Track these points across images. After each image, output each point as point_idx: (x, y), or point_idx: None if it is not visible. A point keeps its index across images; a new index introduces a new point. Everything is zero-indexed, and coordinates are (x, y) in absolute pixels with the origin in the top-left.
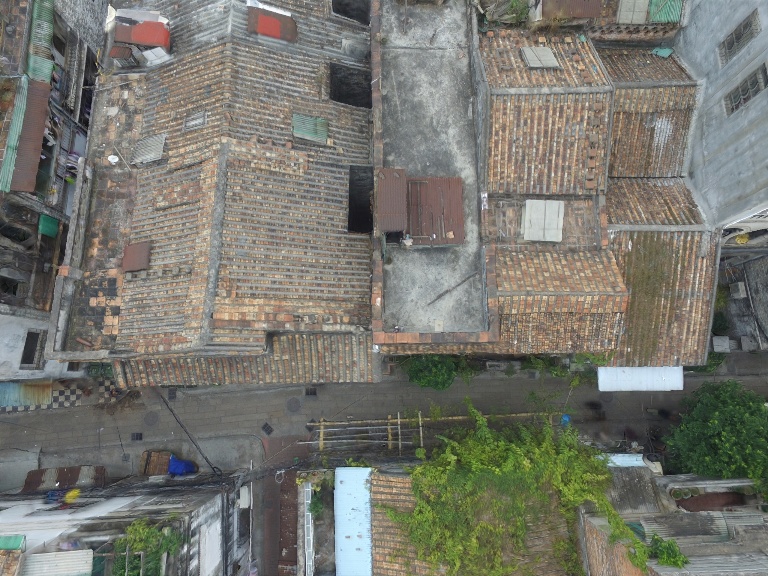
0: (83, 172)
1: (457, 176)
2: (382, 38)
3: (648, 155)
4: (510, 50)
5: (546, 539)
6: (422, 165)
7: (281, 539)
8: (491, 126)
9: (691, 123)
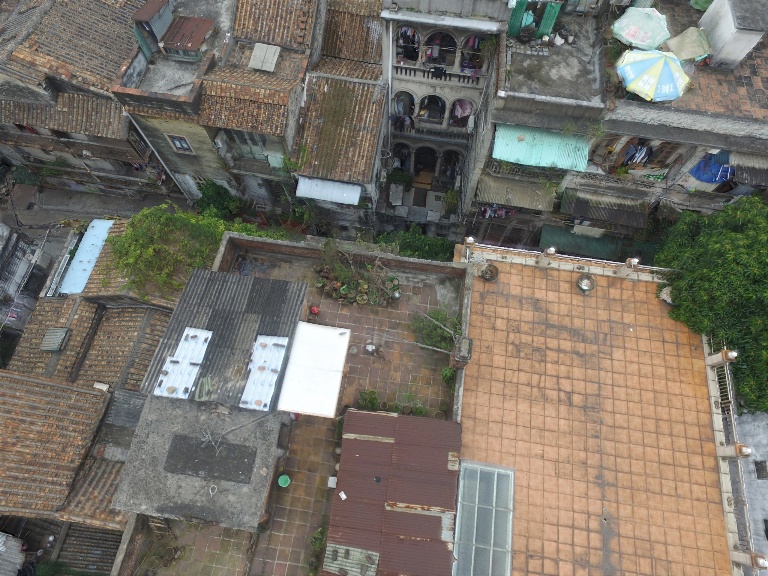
0: None
1: (218, 25)
2: None
3: (365, 46)
4: None
5: None
6: (198, 16)
7: None
8: None
9: None
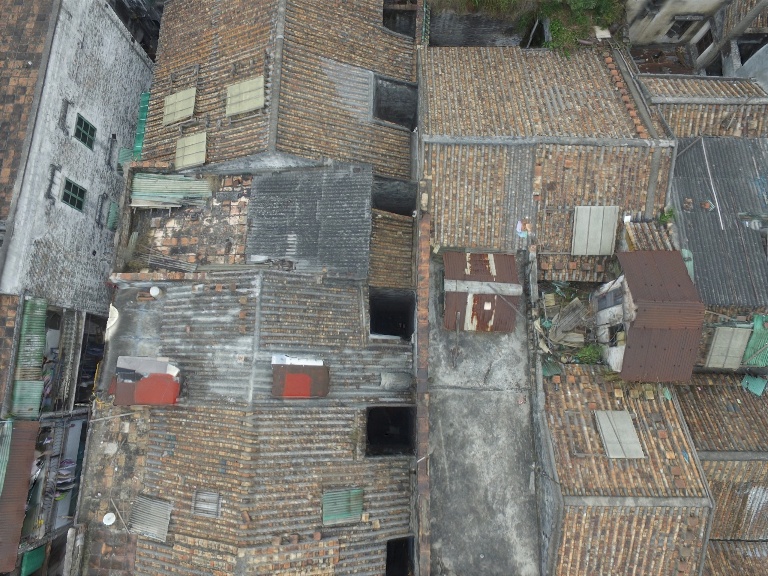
0: (73, 549)
1: (516, 573)
2: (428, 377)
3: (738, 520)
4: (582, 412)
5: None
6: (475, 557)
7: None
8: (562, 536)
9: None
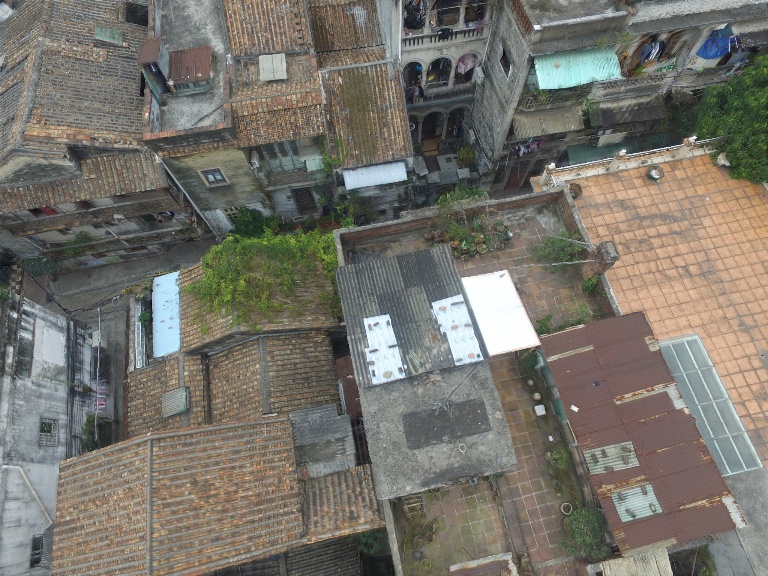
0: None
1: (212, 50)
2: None
3: (355, 32)
4: None
5: (313, 293)
6: (188, 47)
7: (126, 362)
8: (225, 12)
9: (377, 7)
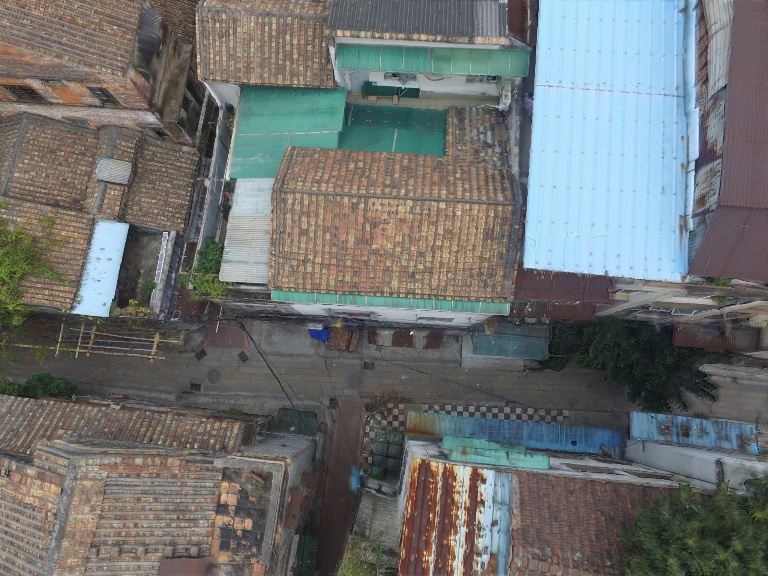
0: None
1: None
2: None
3: None
4: None
5: None
6: None
7: None
8: None
9: None
